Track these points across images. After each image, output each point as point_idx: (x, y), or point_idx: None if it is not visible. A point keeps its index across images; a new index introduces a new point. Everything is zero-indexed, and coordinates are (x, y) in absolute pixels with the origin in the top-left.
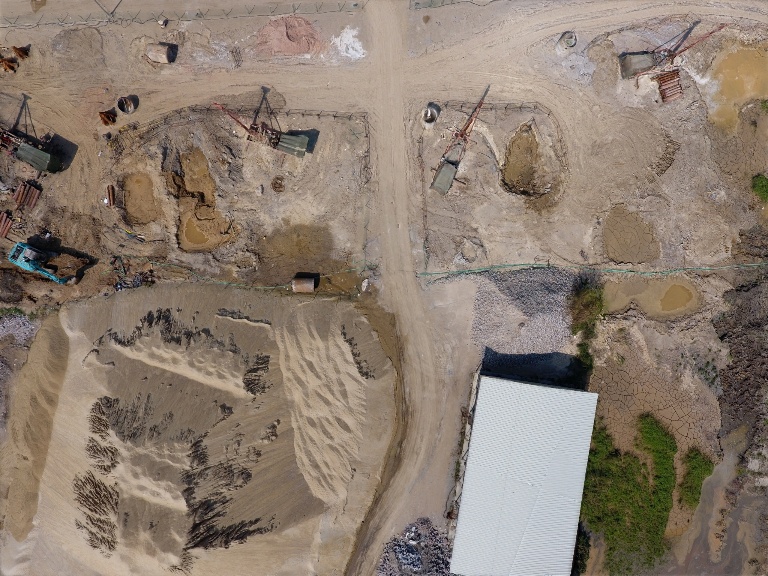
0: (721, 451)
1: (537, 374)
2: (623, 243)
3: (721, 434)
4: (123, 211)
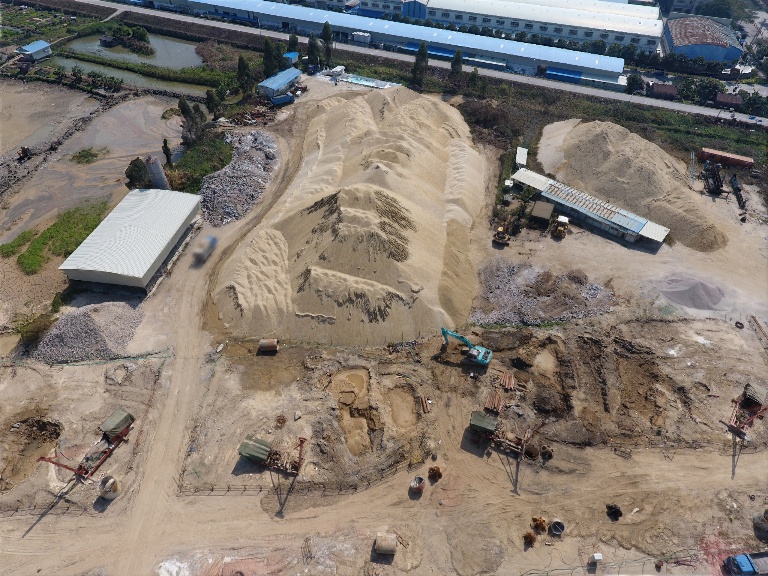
0: None
1: (102, 295)
2: None
3: None
4: (416, 396)
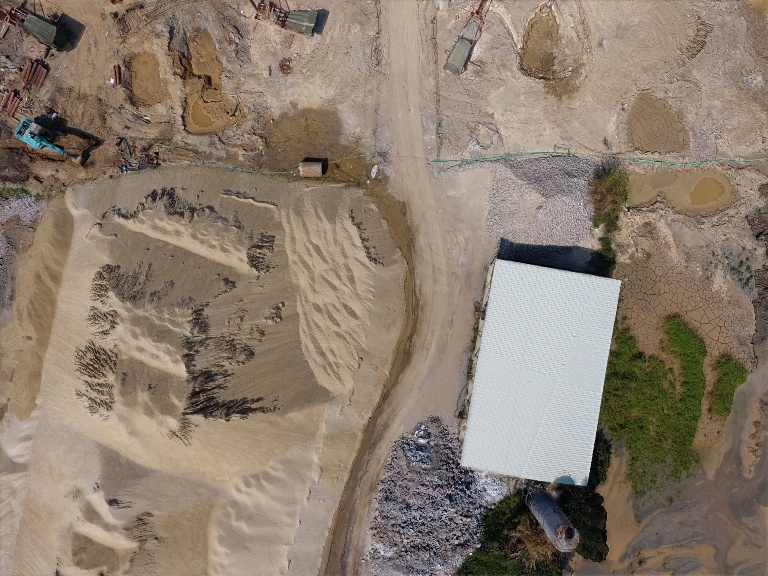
0: (755, 358)
1: None
2: (650, 131)
3: (755, 340)
4: (129, 92)
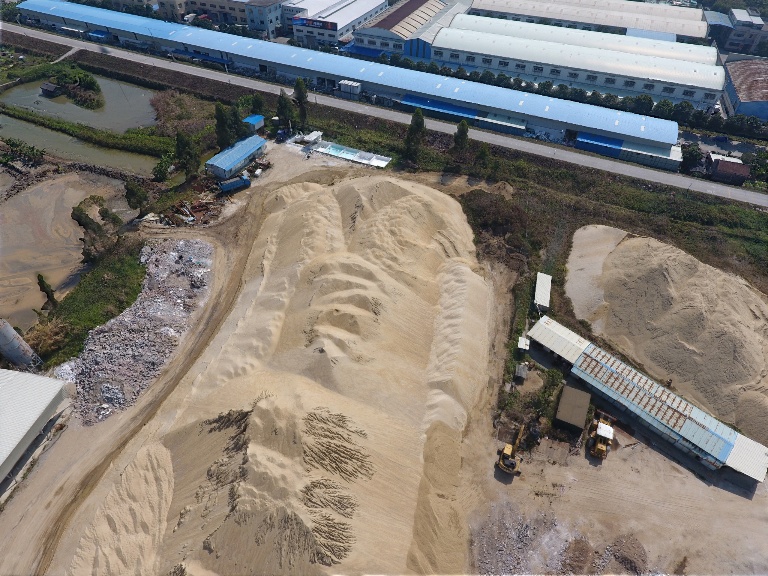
0: None
1: None
2: None
3: None
4: None
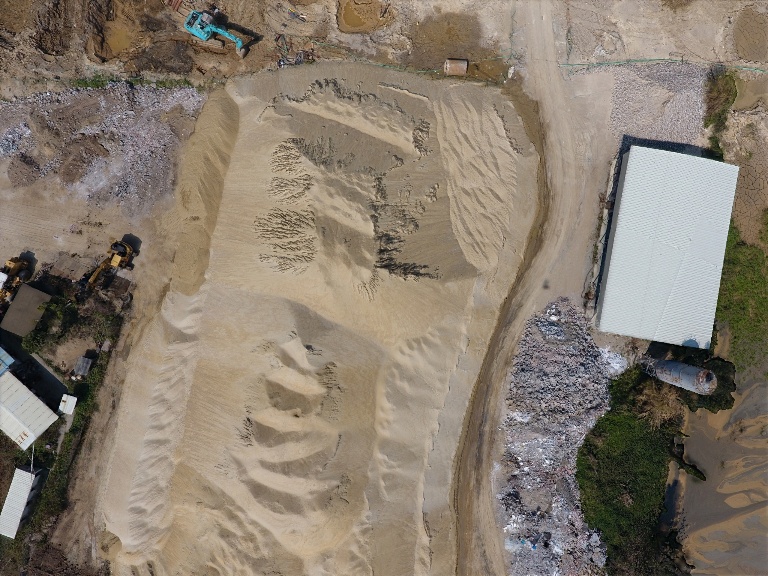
0: None
1: None
2: (752, 43)
3: None
4: None
